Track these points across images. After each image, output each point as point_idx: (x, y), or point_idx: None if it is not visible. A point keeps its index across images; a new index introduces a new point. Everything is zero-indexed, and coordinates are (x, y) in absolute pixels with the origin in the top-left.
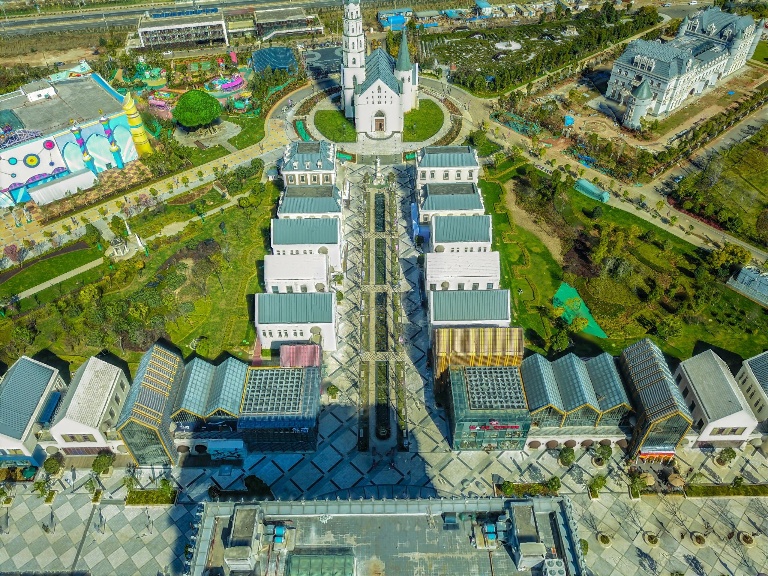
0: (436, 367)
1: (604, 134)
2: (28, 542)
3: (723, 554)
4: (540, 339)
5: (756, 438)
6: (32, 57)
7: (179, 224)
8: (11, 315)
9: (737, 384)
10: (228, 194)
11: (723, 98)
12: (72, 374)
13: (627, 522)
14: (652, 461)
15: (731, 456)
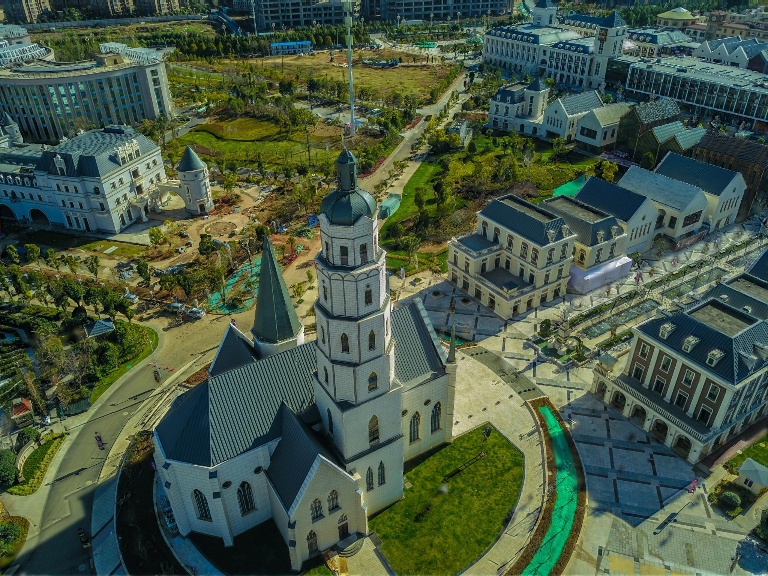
0: None
1: (239, 220)
2: None
3: None
4: None
5: None
6: None
7: None
8: None
9: None
10: None
11: None
12: None
13: None
14: None
15: None
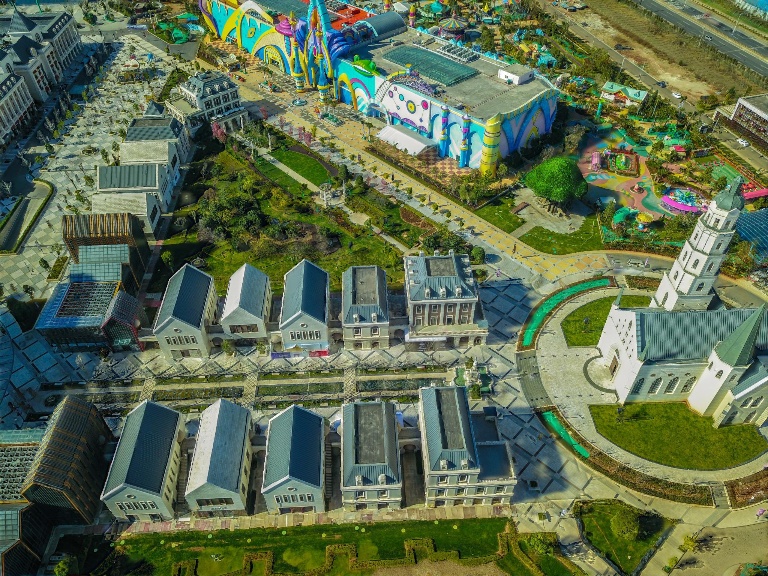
0: None
1: None
2: (55, 225)
3: None
4: (119, 570)
5: None
6: (668, 67)
7: None
8: (254, 164)
9: None
10: None
11: None
12: (186, 206)
13: None
14: None
15: None
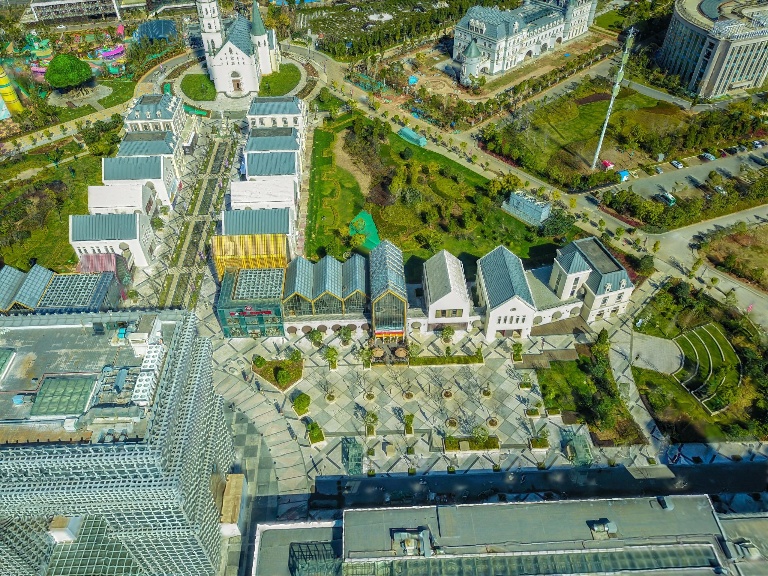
0: (216, 270)
1: (441, 91)
2: None
3: (425, 405)
4: None
5: (476, 320)
6: None
7: (35, 170)
8: None
9: (464, 277)
10: (86, 145)
11: (558, 59)
12: None
13: (354, 385)
14: (389, 341)
15: (449, 333)
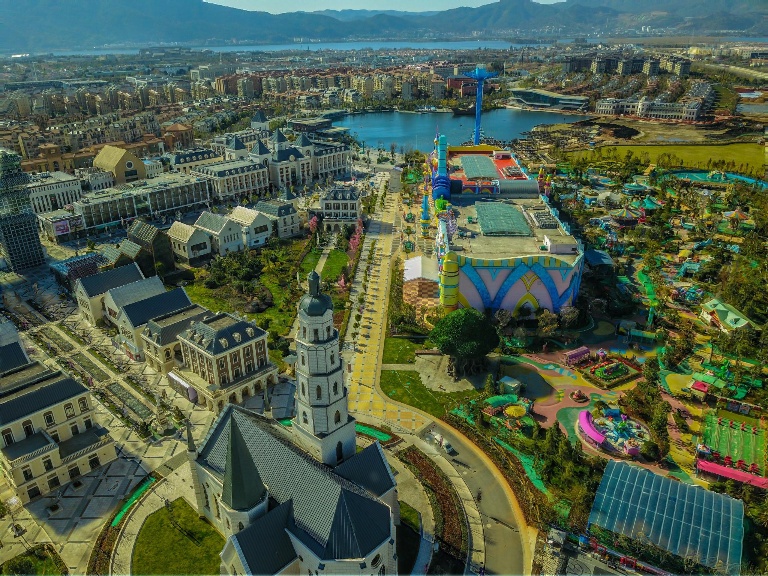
0: None
1: None
2: None
3: None
4: None
5: None
6: None
7: None
8: None
9: None
10: None
11: None
12: None
13: None
14: None
15: None
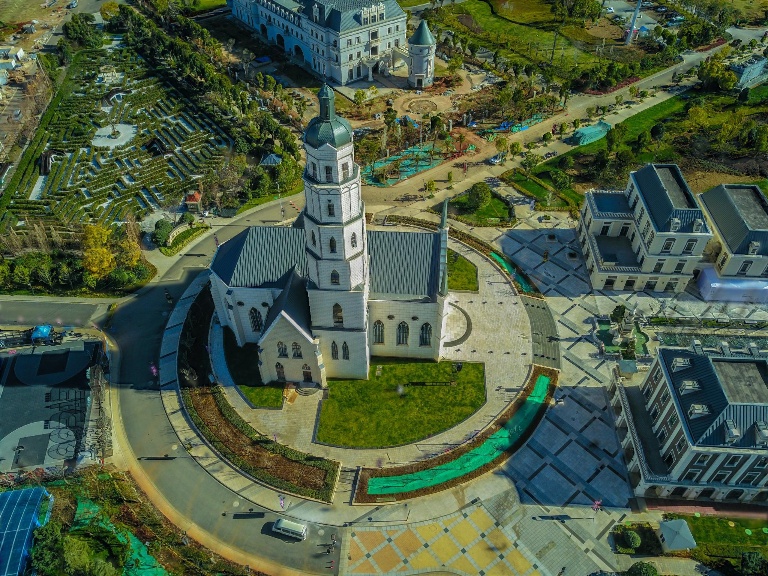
0: None
1: (443, 104)
2: None
3: None
4: None
5: None
6: None
7: None
8: None
9: None
10: None
11: None
12: None
13: None
14: None
15: None
